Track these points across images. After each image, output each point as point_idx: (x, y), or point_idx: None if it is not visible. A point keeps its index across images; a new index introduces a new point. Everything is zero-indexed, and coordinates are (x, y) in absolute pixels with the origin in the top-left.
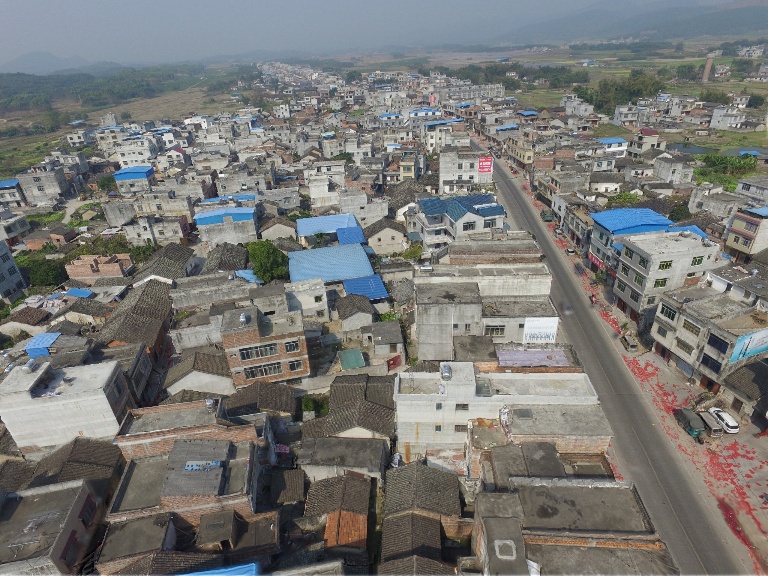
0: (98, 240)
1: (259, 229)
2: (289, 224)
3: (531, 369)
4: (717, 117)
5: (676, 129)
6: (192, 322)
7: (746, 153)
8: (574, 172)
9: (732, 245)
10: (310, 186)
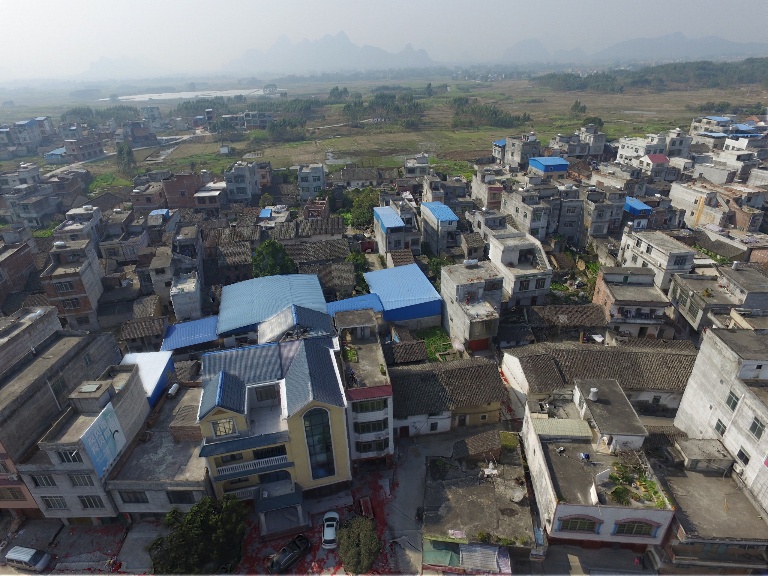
0: None
1: None
2: (401, 262)
3: None
4: None
5: None
6: (159, 250)
7: None
8: None
9: None
10: (491, 241)
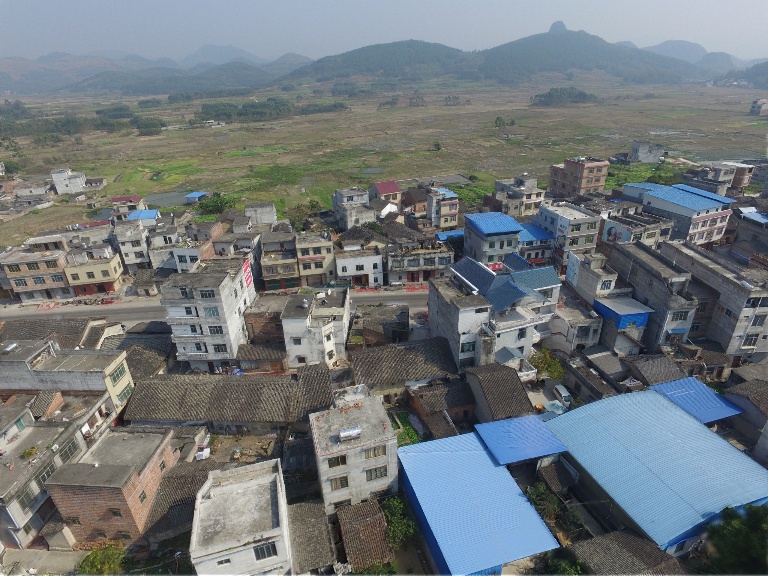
0: None
1: None
2: None
3: None
4: (61, 181)
5: (47, 202)
6: None
7: (215, 192)
8: (301, 235)
9: (445, 225)
10: (282, 534)
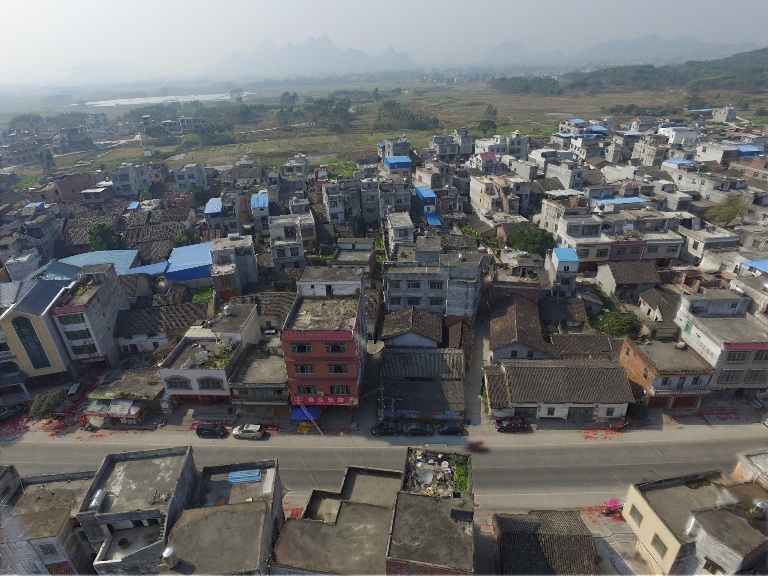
0: None
1: None
2: (209, 239)
3: None
4: None
5: None
6: None
7: None
8: None
9: None
10: None
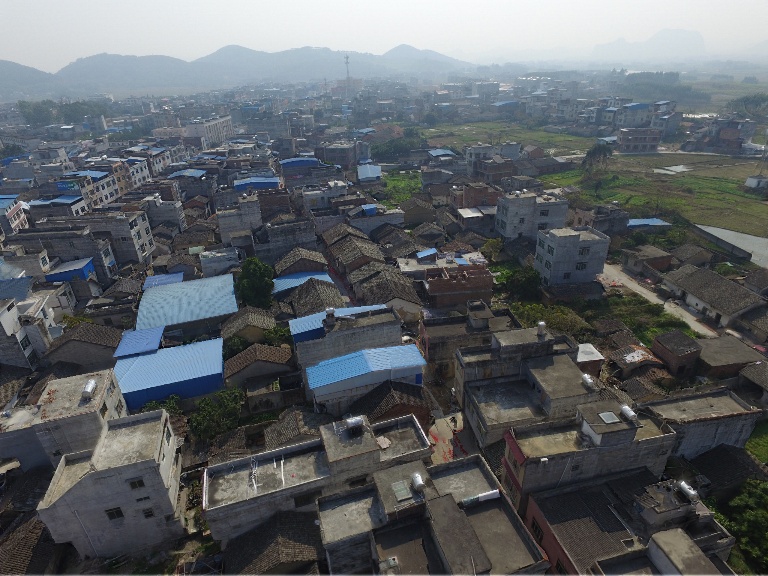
0: (615, 366)
1: (292, 356)
2: (236, 361)
3: (116, 208)
4: None
5: None
6: None
7: None
8: None
9: None
10: None
